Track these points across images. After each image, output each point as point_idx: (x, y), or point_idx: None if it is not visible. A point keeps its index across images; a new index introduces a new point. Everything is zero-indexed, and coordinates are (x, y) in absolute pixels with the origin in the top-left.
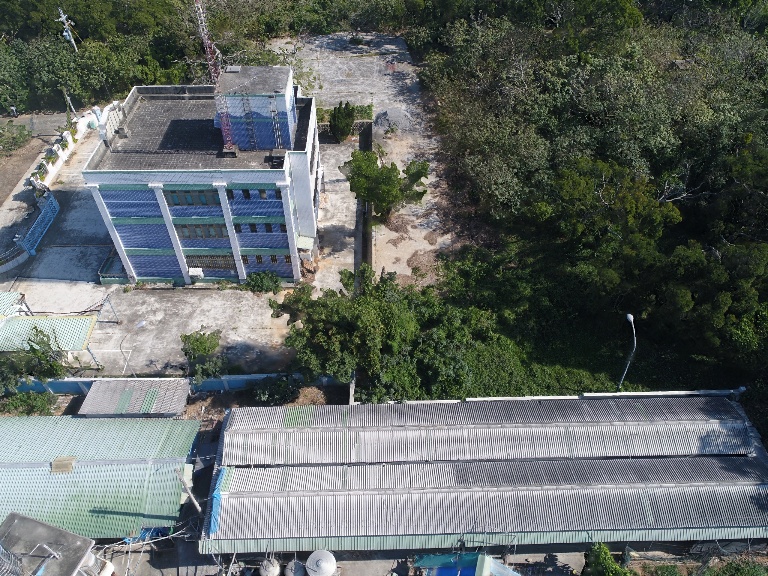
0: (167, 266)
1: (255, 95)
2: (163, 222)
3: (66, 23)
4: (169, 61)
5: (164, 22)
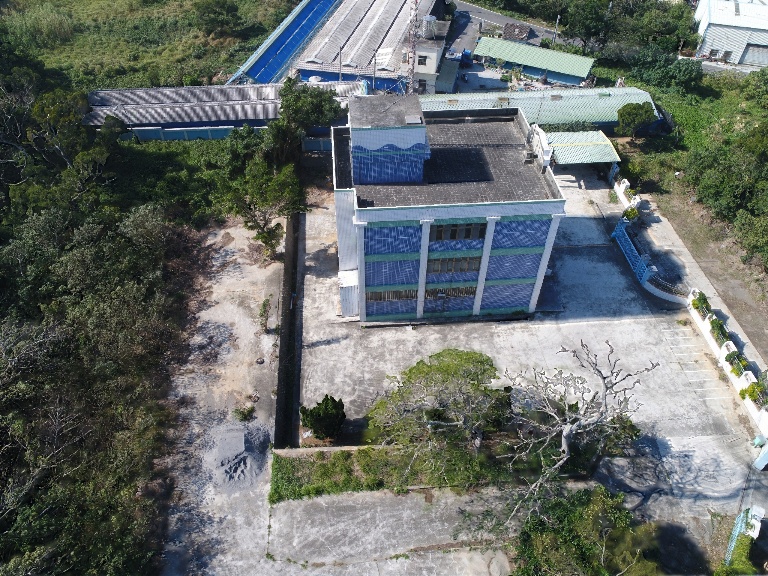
0: None
1: None
2: None
3: None
4: None
5: None
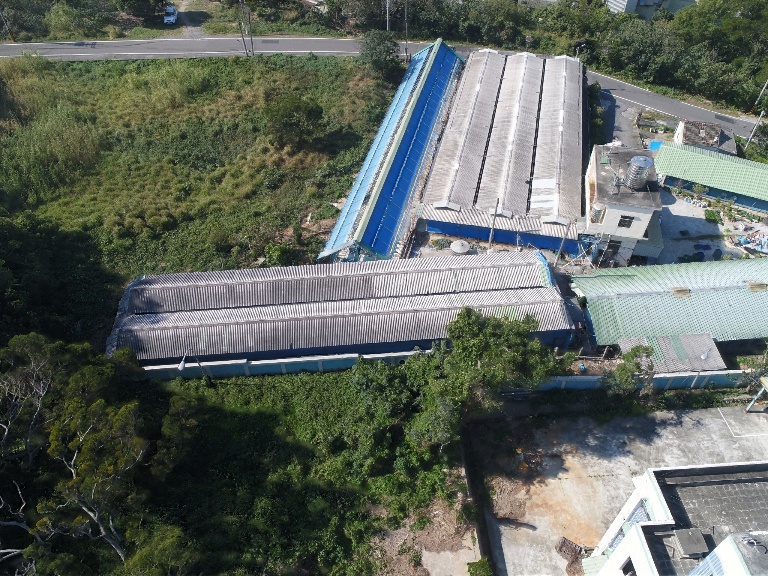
0: None
1: None
2: None
3: None
4: None
5: None
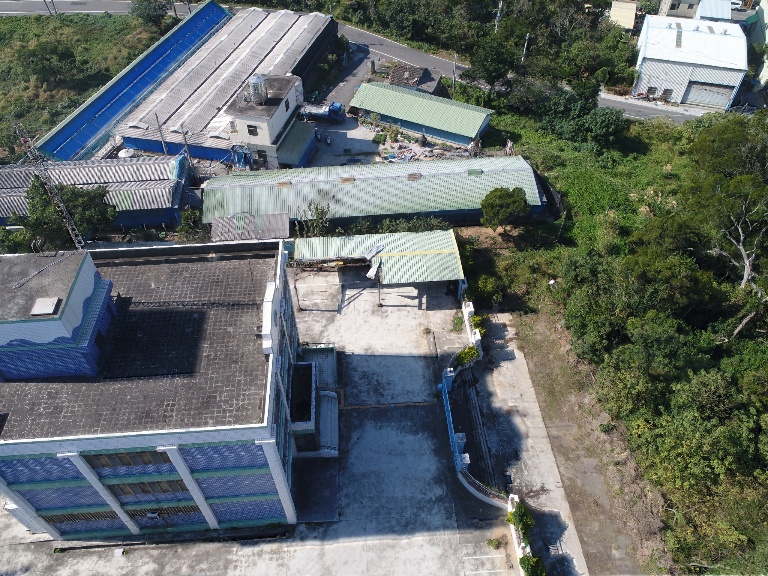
0: None
1: None
2: None
3: None
4: None
5: None
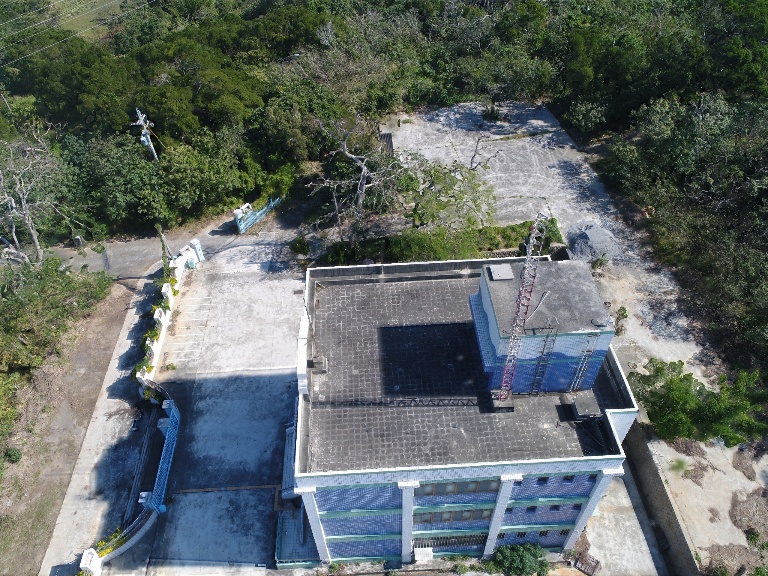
0: (381, 547)
1: (567, 334)
2: (398, 512)
3: (144, 125)
4: (273, 162)
5: (268, 115)
